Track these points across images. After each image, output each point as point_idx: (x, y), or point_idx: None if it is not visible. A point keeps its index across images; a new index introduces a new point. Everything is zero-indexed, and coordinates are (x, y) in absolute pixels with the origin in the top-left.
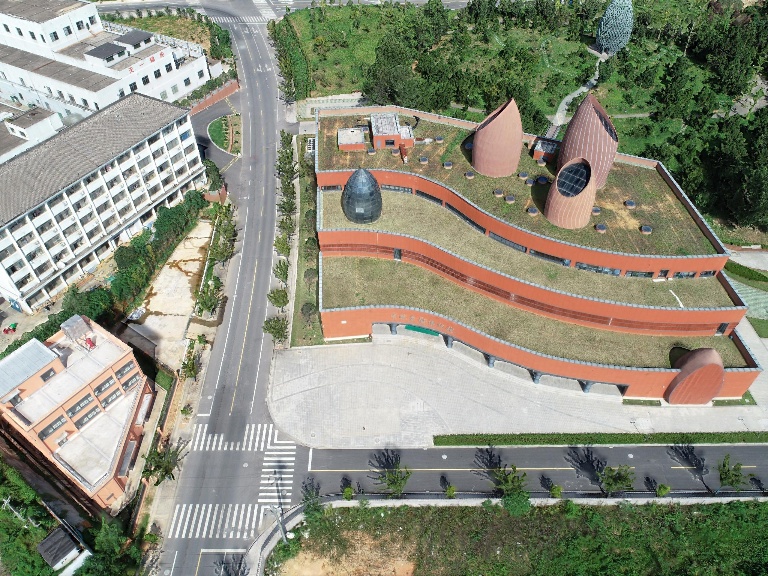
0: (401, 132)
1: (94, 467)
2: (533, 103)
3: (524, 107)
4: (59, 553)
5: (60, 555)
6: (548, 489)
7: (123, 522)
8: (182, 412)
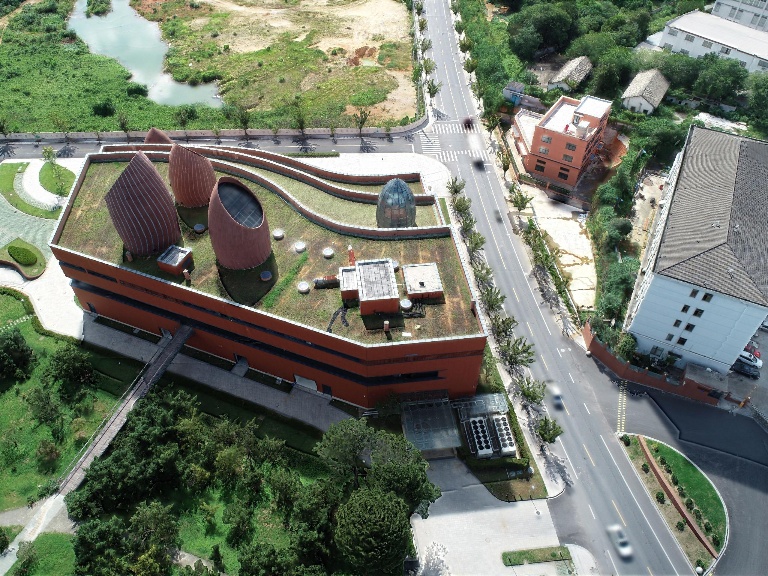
0: (355, 282)
1: (528, 120)
2: (64, 573)
3: (121, 462)
4: (513, 83)
5: (512, 83)
6: (277, 140)
7: (504, 127)
8: (499, 154)
